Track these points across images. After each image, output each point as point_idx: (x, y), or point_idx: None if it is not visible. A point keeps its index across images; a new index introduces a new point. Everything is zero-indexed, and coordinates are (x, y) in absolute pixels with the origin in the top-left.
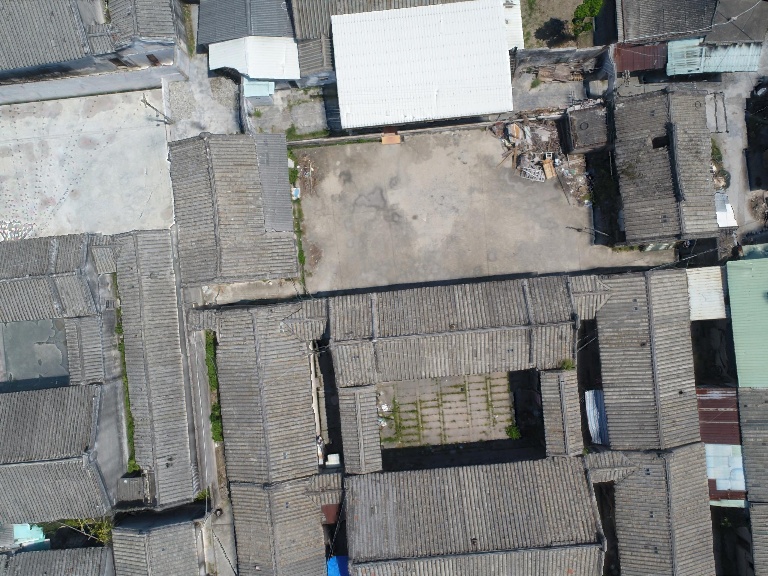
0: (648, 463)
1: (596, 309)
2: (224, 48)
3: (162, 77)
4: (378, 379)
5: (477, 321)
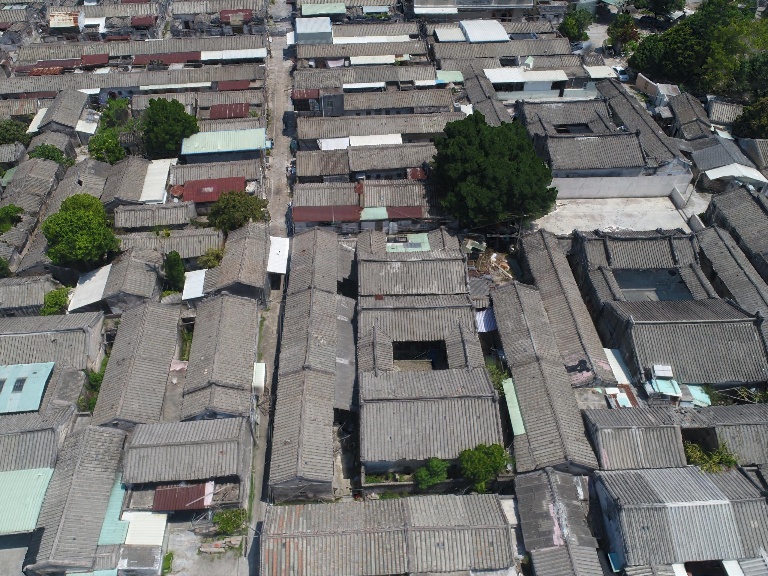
0: None
1: None
2: (719, 170)
3: (676, 186)
4: None
5: None
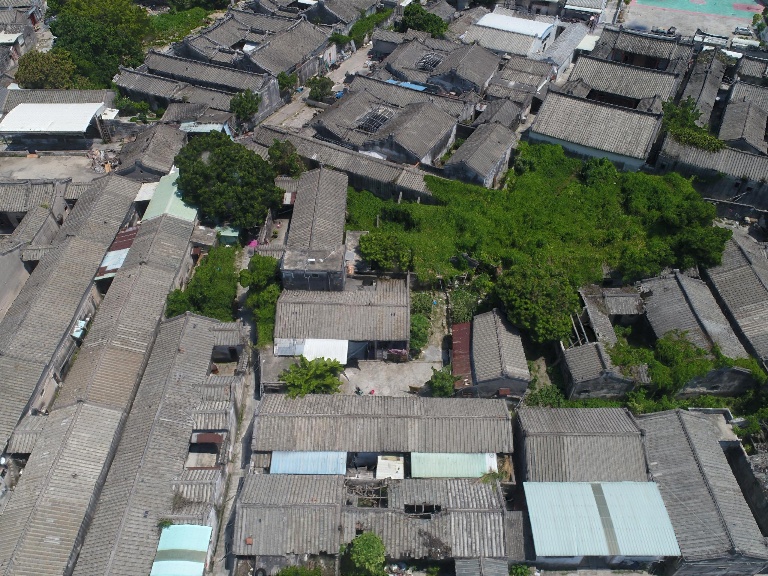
0: (60, 243)
1: (81, 193)
2: None
3: None
4: None
5: None
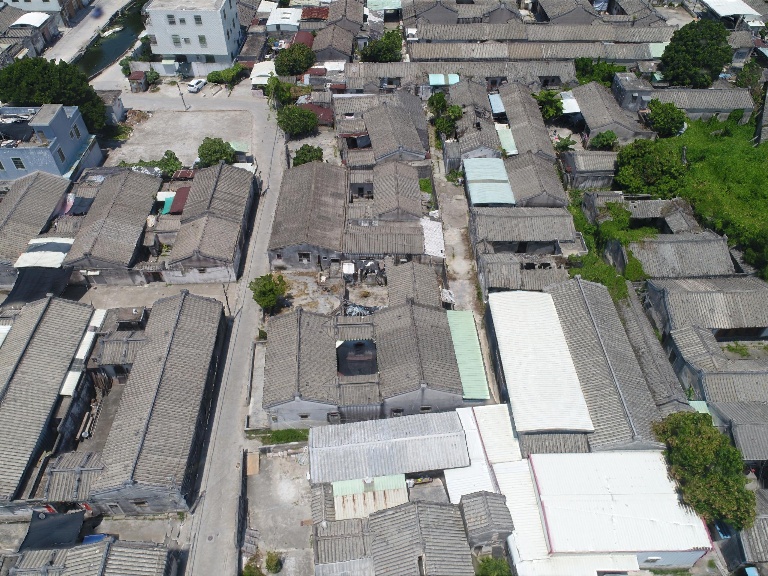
0: None
1: None
2: None
3: None
4: None
5: None
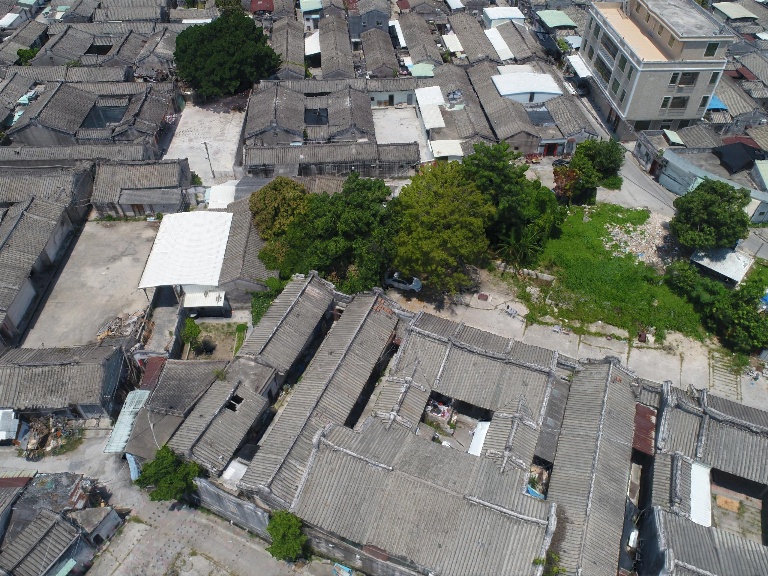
0: None
1: None
2: None
3: None
4: (3, 223)
5: (4, 257)
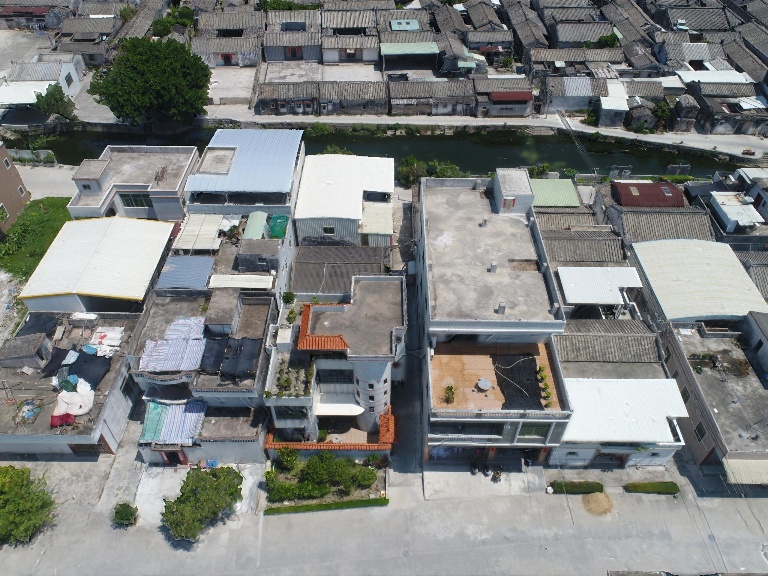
0: None
1: None
2: None
3: None
4: None
5: None
